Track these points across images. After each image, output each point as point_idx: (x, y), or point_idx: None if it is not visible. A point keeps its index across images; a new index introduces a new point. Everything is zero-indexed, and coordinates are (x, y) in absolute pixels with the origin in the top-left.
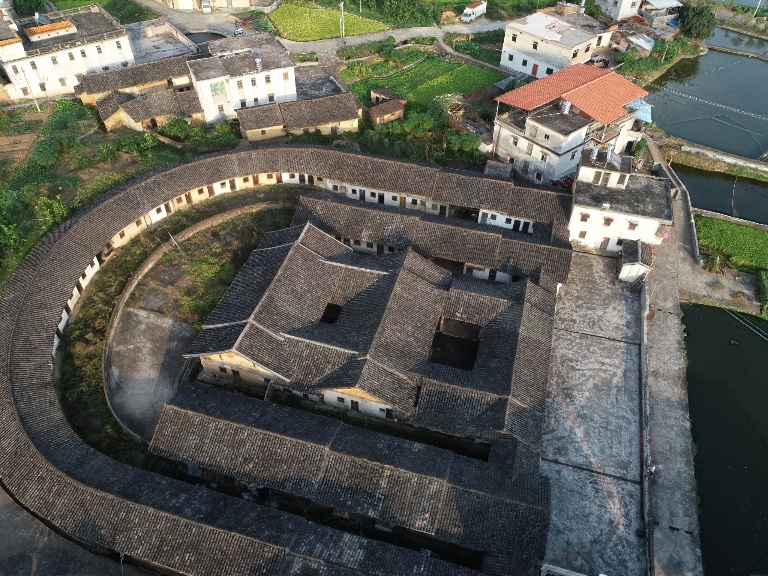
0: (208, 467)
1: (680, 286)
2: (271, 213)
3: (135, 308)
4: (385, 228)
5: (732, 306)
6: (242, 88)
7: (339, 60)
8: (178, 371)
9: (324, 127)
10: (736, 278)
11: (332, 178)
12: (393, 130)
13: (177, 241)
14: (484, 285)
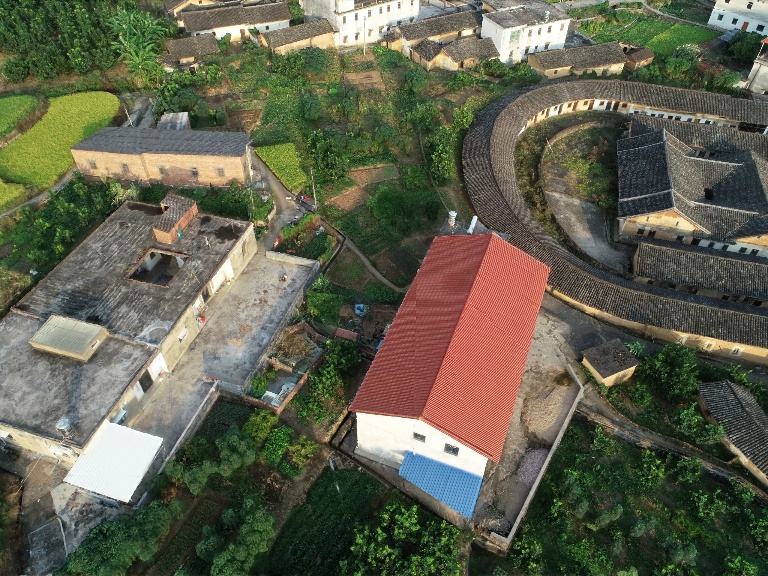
0: (690, 284)
1: None
2: (597, 131)
3: (548, 191)
4: (711, 137)
5: None
6: (530, 36)
7: (572, 19)
8: (602, 234)
9: (598, 69)
10: None
11: (641, 103)
12: (654, 72)
13: (548, 147)
14: None
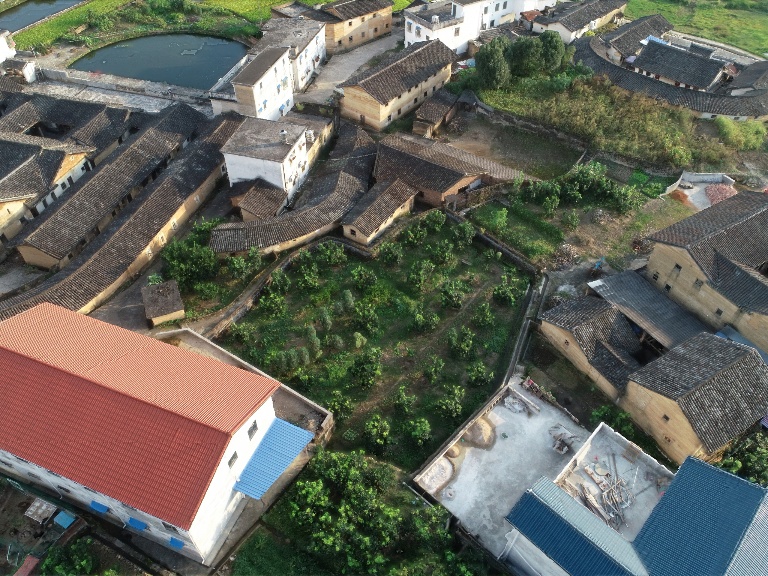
0: (92, 226)
1: (52, 65)
2: None
3: None
4: None
5: (79, 55)
6: None
7: None
8: None
9: None
10: (59, 48)
11: None
12: None
13: None
14: (0, 117)
